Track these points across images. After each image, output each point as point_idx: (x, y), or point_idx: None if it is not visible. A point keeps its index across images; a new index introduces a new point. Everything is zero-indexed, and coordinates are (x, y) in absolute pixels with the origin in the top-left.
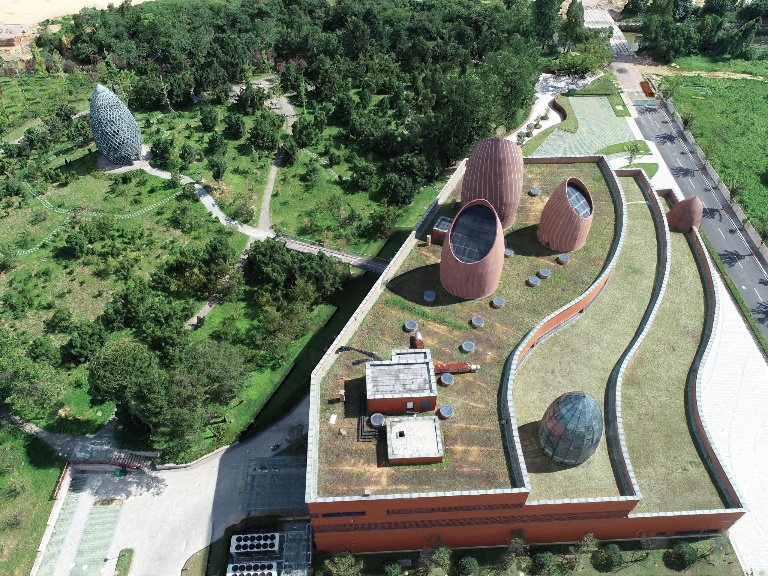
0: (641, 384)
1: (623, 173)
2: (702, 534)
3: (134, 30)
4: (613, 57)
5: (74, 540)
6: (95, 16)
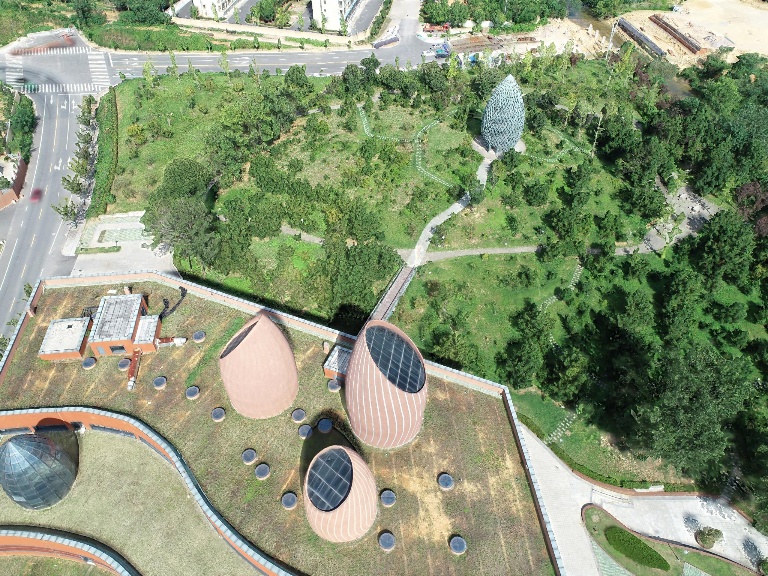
0: None
1: None
2: None
3: (766, 99)
4: None
5: (134, 226)
6: (753, 65)
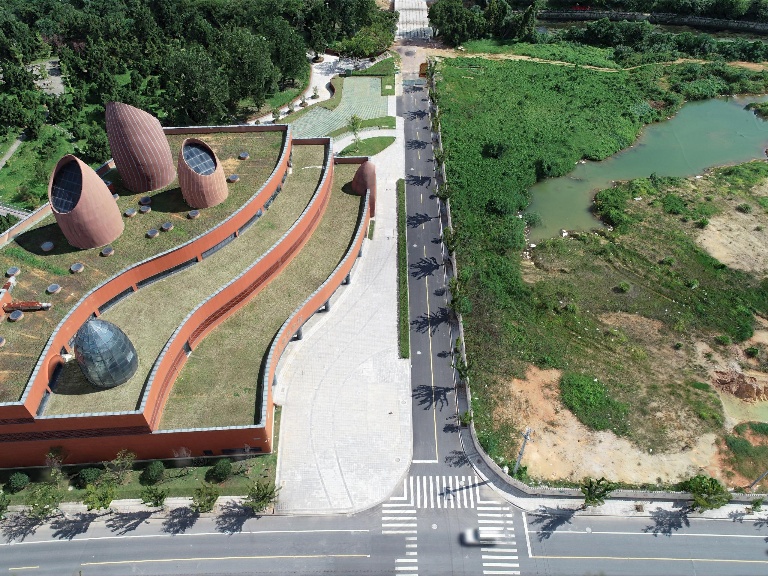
0: (241, 325)
1: (315, 141)
2: (250, 453)
3: None
4: (408, 41)
5: None
6: None
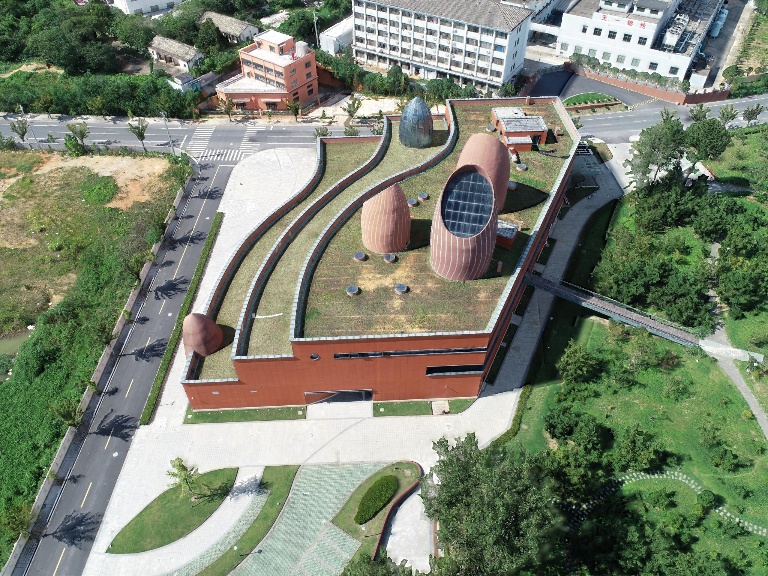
0: None
1: None
2: None
3: None
4: None
5: None
6: None
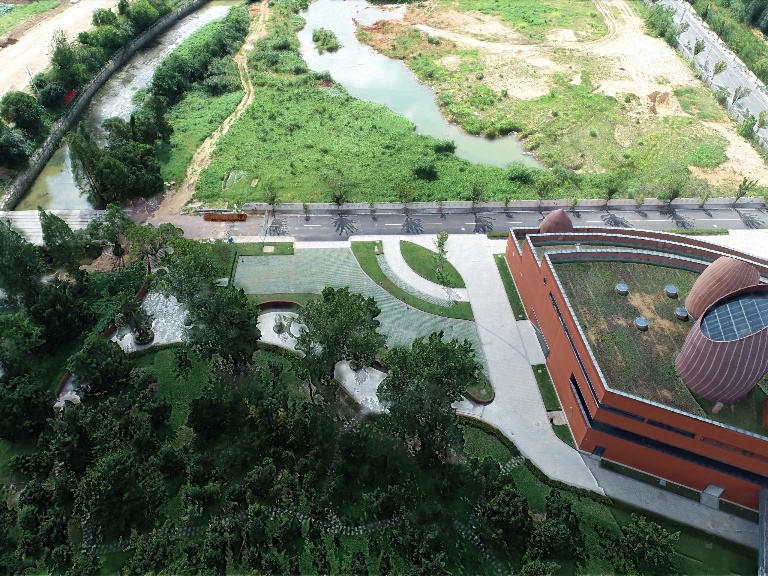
0: None
1: None
2: None
3: None
4: None
5: None
6: None
